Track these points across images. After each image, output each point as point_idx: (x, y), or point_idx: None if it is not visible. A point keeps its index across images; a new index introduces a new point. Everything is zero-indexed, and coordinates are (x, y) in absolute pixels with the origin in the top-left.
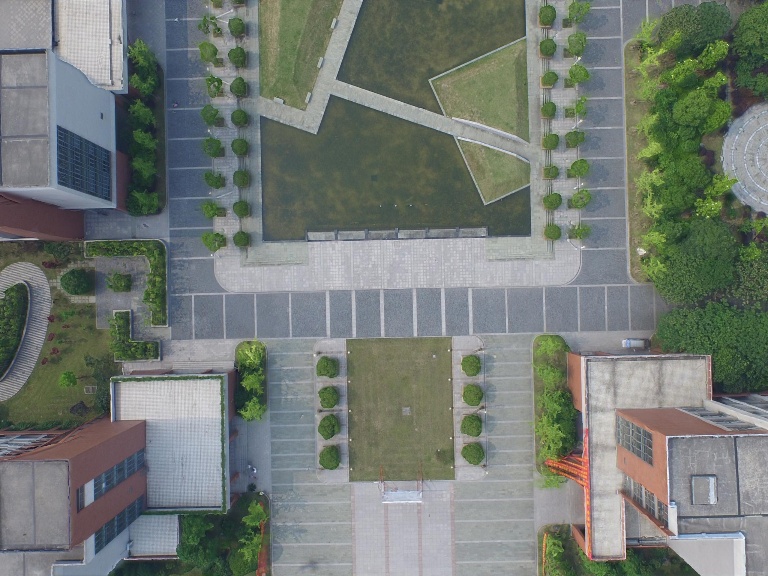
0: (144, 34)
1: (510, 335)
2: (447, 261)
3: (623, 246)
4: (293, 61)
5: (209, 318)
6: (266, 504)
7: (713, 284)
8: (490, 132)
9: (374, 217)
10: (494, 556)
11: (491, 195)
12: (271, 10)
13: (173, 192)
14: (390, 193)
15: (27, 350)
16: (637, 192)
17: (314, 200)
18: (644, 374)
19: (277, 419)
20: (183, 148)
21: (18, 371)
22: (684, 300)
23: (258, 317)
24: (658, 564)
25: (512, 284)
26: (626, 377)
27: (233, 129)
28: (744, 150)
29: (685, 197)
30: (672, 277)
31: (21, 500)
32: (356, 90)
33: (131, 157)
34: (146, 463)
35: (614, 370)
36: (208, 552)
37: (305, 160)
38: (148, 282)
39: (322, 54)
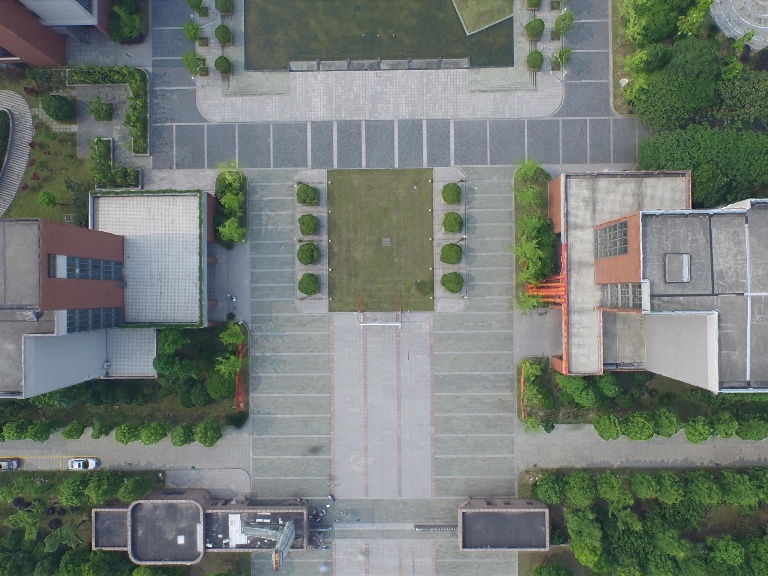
0: None
1: (491, 167)
2: (429, 92)
3: (606, 79)
4: None
5: (190, 148)
6: (245, 334)
7: (694, 103)
8: None
9: (356, 47)
10: (473, 388)
11: (474, 25)
12: None
13: (156, 22)
14: (373, 23)
15: (8, 178)
16: (620, 15)
17: (297, 30)
18: (624, 191)
19: (257, 249)
20: None
21: None
22: (666, 125)
23: (239, 147)
24: (637, 393)
25: (494, 116)
26: (605, 194)
27: None
28: None
29: (667, 16)
30: (653, 98)
31: None
32: None
33: None
34: (124, 278)
35: (593, 187)
36: (184, 363)
37: None
38: (129, 106)
39: None
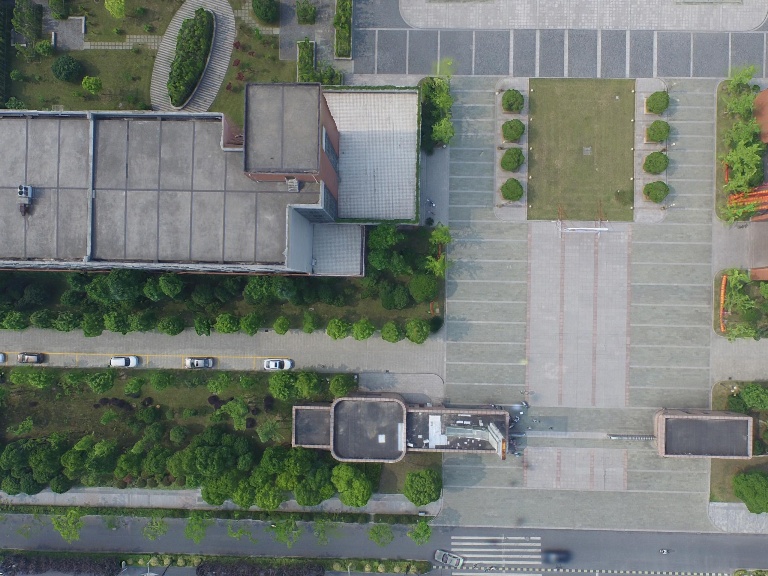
0: None
1: (694, 79)
2: (634, 3)
3: None
4: None
5: (392, 53)
6: None
7: None
8: None
9: None
10: (670, 299)
11: None
12: None
13: None
14: None
15: (210, 79)
16: None
17: None
18: None
19: (456, 156)
20: None
21: (200, 99)
22: None
23: (441, 54)
24: None
25: (698, 28)
26: None
27: None
28: None
29: None
30: None
31: (270, 124)
32: None
33: None
34: (338, 174)
35: None
36: (402, 258)
37: None
38: (338, 7)
39: None
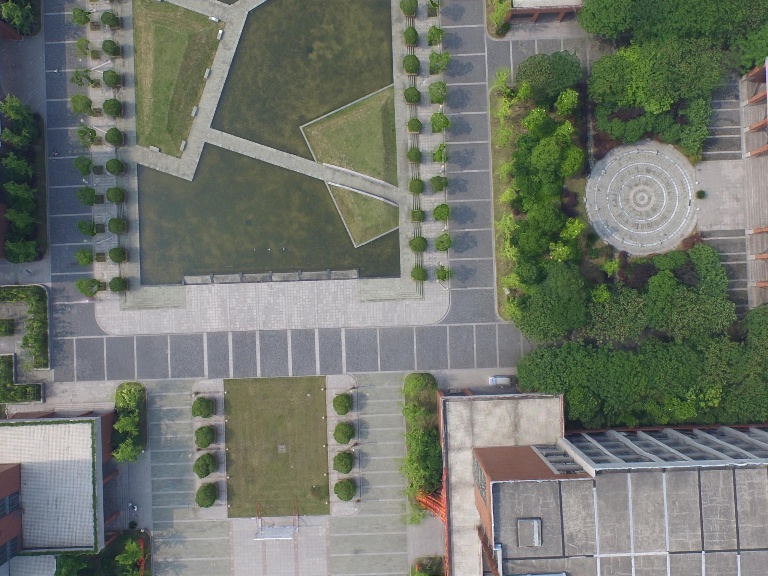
0: (25, 85)
1: (382, 373)
2: (320, 302)
3: (491, 286)
4: (166, 111)
5: (90, 360)
6: (147, 541)
7: (567, 325)
8: (359, 177)
9: (249, 261)
10: None
11: (361, 238)
12: (145, 62)
13: (54, 238)
14: (264, 237)
15: None
16: (496, 235)
17: (190, 245)
18: (500, 413)
19: (157, 458)
20: (64, 195)
21: None
22: (544, 339)
23: (138, 359)
24: None
25: (383, 324)
26: (483, 416)
27: (112, 177)
28: (607, 191)
29: (539, 241)
30: (529, 318)
31: None
32: (230, 138)
33: (10, 206)
34: (21, 505)
35: (471, 410)
36: None
37: (181, 206)
38: (27, 327)
39: (196, 103)
